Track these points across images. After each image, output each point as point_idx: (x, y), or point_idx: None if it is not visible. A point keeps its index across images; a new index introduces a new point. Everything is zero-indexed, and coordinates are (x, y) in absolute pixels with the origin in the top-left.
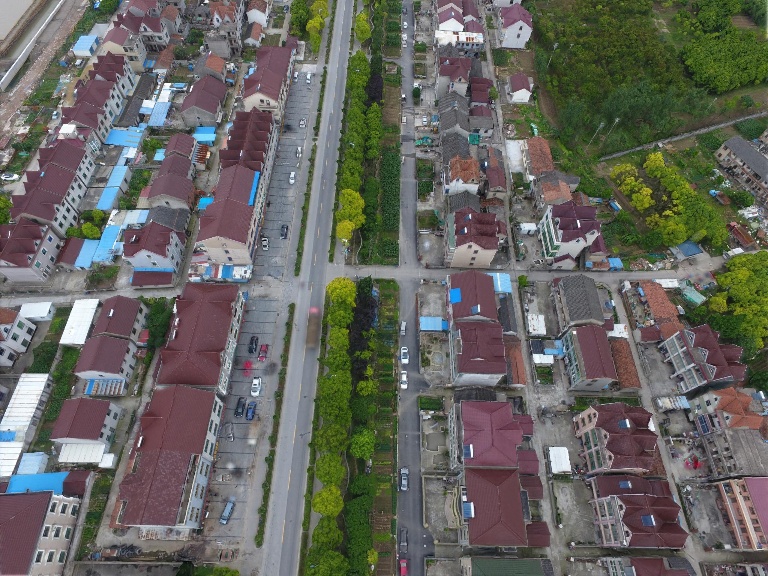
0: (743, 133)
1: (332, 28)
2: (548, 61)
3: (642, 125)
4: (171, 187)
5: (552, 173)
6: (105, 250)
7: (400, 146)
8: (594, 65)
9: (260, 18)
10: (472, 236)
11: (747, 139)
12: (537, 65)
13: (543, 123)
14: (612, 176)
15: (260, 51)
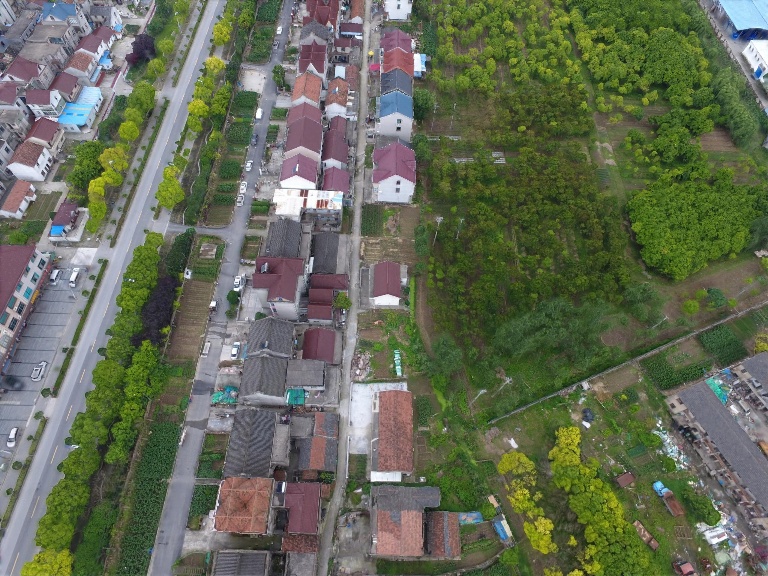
0: (710, 353)
1: (138, 179)
2: (435, 232)
3: (555, 365)
4: None
5: (394, 492)
6: None
7: (186, 406)
8: (501, 236)
9: (29, 172)
10: None
11: (715, 364)
12: (415, 245)
13: (413, 350)
14: (500, 471)
15: None
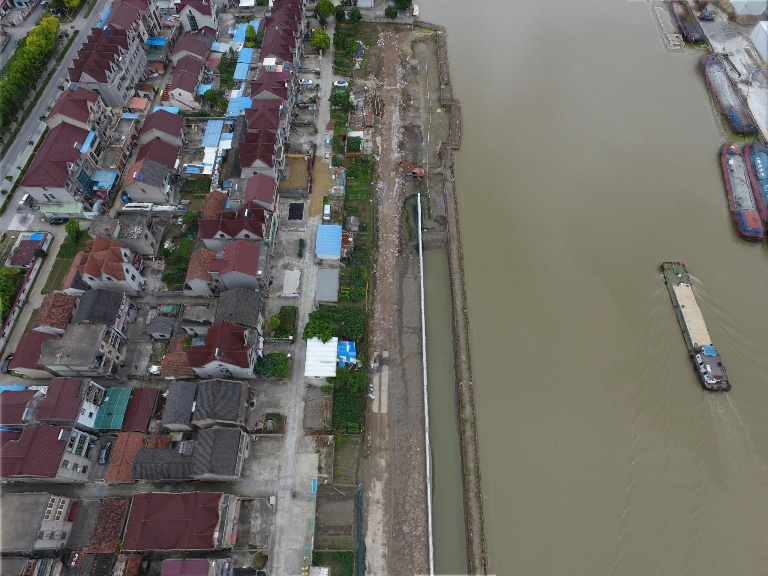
0: None
1: None
2: None
3: None
4: None
5: None
6: (241, 28)
7: None
8: None
9: None
10: None
11: None
12: None
13: None
14: None
15: (62, 161)
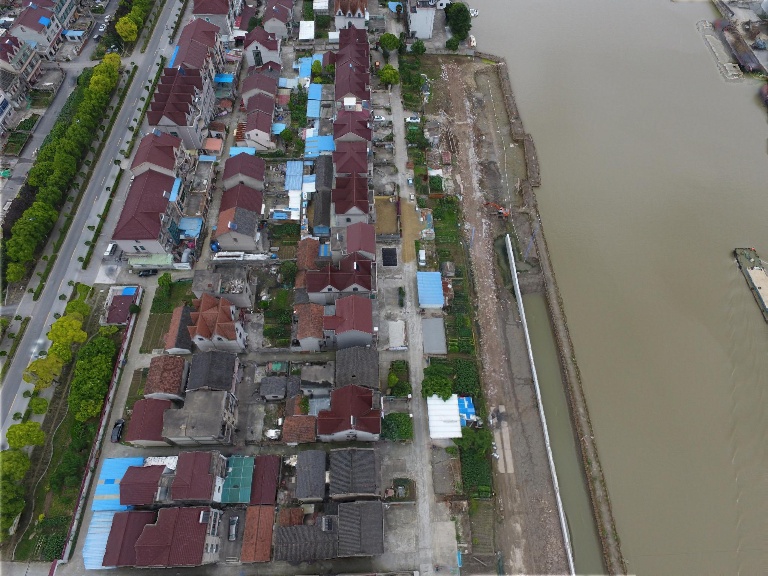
0: None
1: None
2: None
3: None
4: (254, 80)
5: None
6: (305, 63)
7: None
8: None
9: None
10: (5, 37)
11: None
12: None
13: None
14: None
15: (154, 212)
